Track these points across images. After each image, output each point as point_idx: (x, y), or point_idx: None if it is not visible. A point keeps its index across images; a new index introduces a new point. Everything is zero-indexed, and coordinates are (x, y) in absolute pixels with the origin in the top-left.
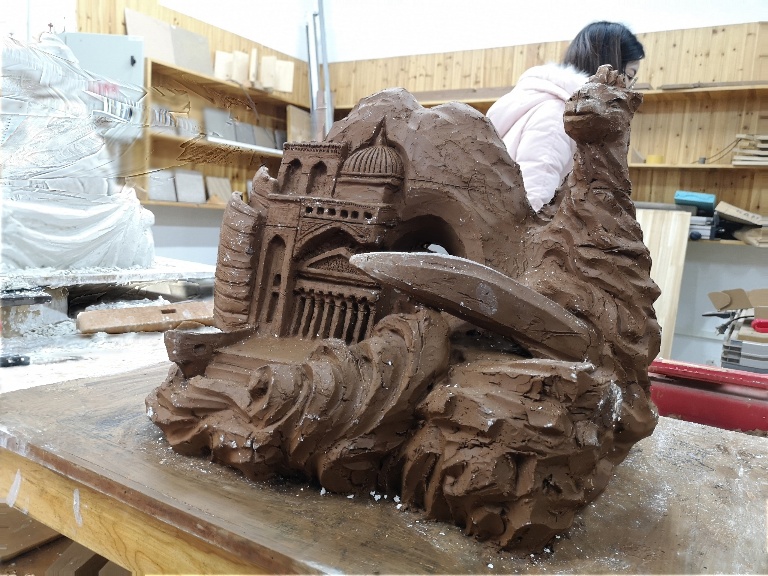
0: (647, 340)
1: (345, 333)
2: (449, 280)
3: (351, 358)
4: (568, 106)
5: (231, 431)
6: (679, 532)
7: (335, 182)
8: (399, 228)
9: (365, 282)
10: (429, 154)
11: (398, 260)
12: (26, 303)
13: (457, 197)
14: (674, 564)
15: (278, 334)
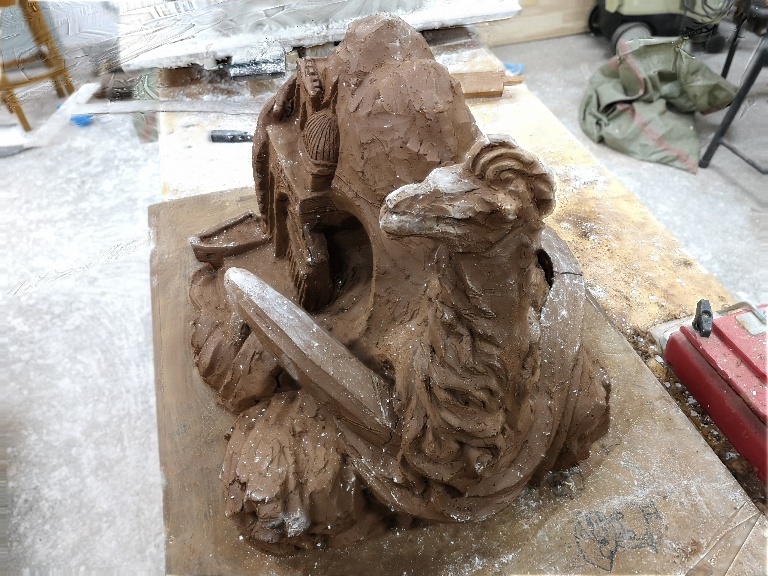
0: (459, 467)
1: (297, 286)
2: (265, 337)
3: (235, 341)
4: None
5: None
6: None
7: None
8: (340, 212)
9: None
10: (353, 151)
11: (240, 297)
12: (266, 78)
13: (366, 215)
14: None
15: (275, 255)
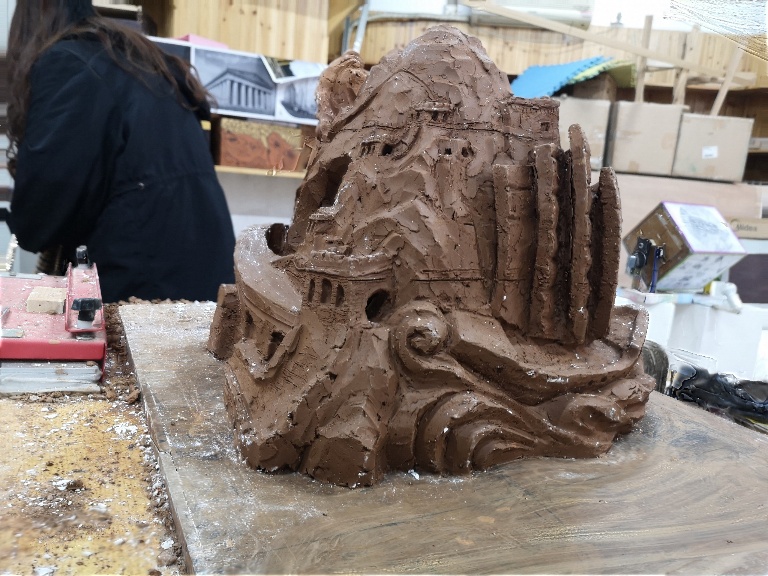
0: None
1: None
2: None
3: None
4: None
5: None
6: None
7: None
8: None
9: None
10: None
11: None
12: None
13: None
14: None
15: None
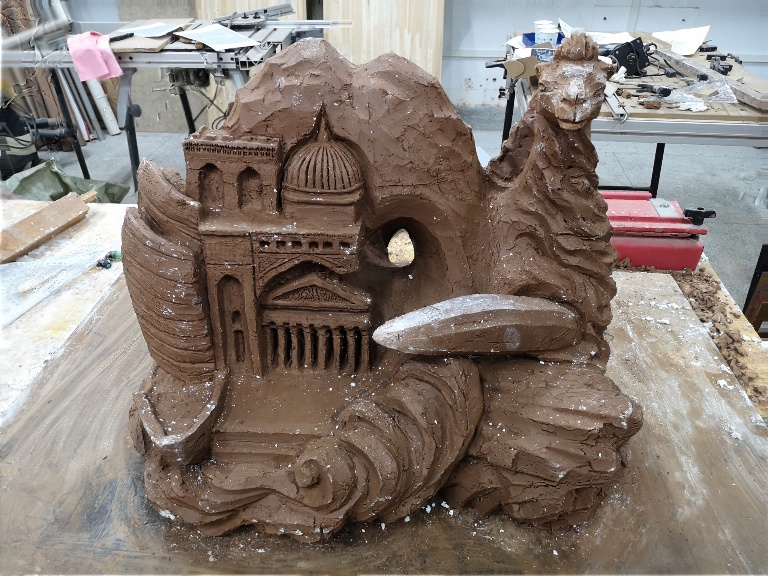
0: None
1: (338, 360)
2: (480, 335)
3: (392, 423)
4: (565, 113)
5: (291, 523)
6: (634, 437)
7: (277, 193)
8: (367, 235)
9: (351, 309)
10: (392, 151)
11: (430, 331)
12: None
13: (430, 197)
14: (651, 479)
15: (260, 375)
